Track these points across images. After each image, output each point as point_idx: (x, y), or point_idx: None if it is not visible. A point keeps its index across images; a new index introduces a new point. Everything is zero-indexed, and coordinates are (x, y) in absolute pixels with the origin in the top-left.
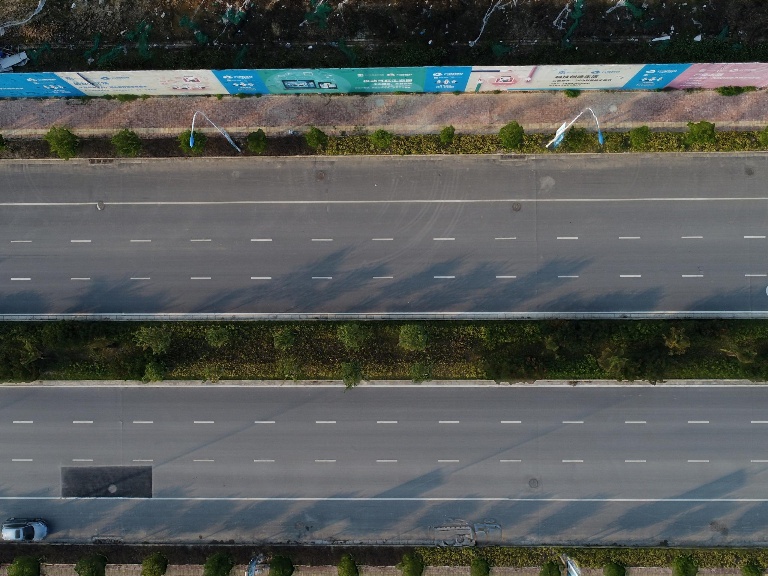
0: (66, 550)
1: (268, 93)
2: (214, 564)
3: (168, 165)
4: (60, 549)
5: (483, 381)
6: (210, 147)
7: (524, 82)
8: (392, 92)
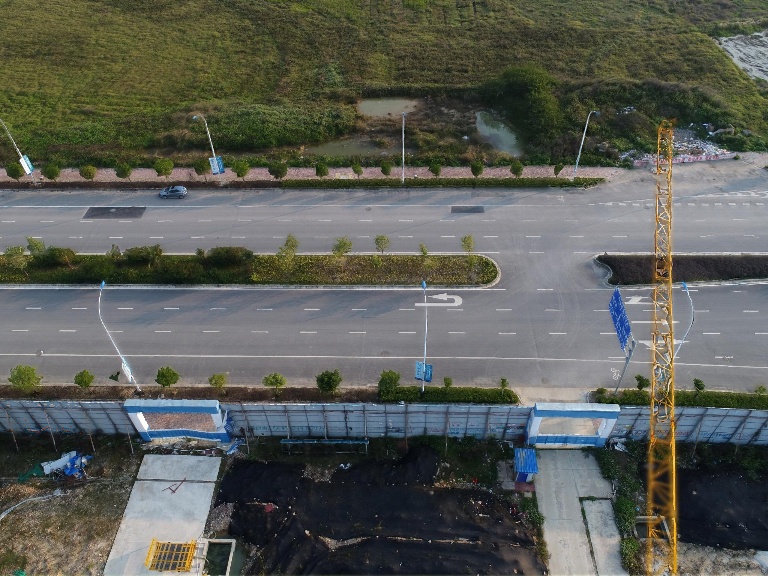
0: (152, 186)
1: None
2: (47, 170)
3: None
4: (156, 186)
5: None
6: None
7: None
8: None
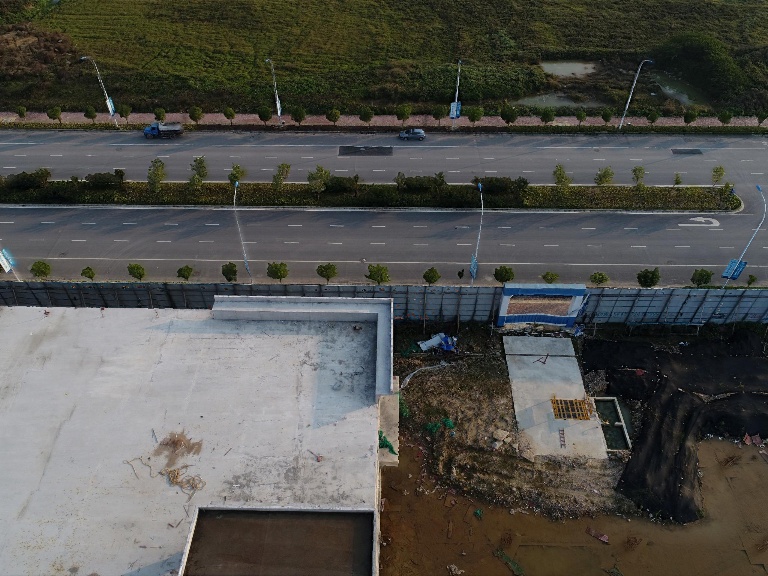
0: (389, 129)
1: None
2: (298, 112)
3: (310, 281)
4: (393, 130)
5: None
6: None
7: None
8: None
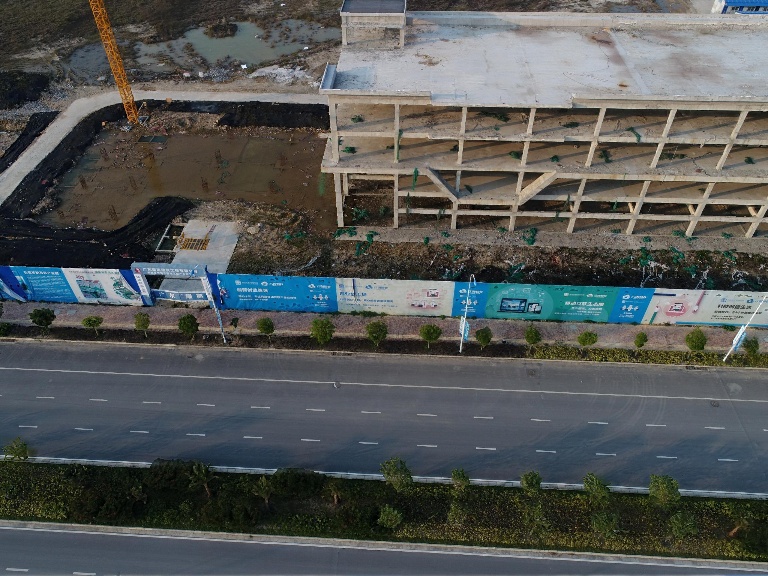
0: None
1: (482, 317)
2: None
3: (398, 359)
4: None
5: (744, 563)
6: (435, 348)
7: (691, 312)
8: (582, 321)
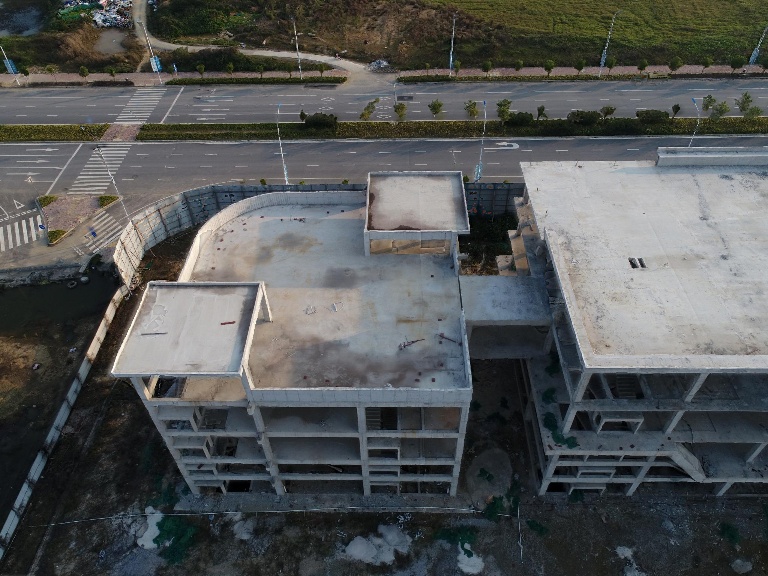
0: None
1: None
2: None
3: None
4: None
5: None
6: None
7: None
8: None
